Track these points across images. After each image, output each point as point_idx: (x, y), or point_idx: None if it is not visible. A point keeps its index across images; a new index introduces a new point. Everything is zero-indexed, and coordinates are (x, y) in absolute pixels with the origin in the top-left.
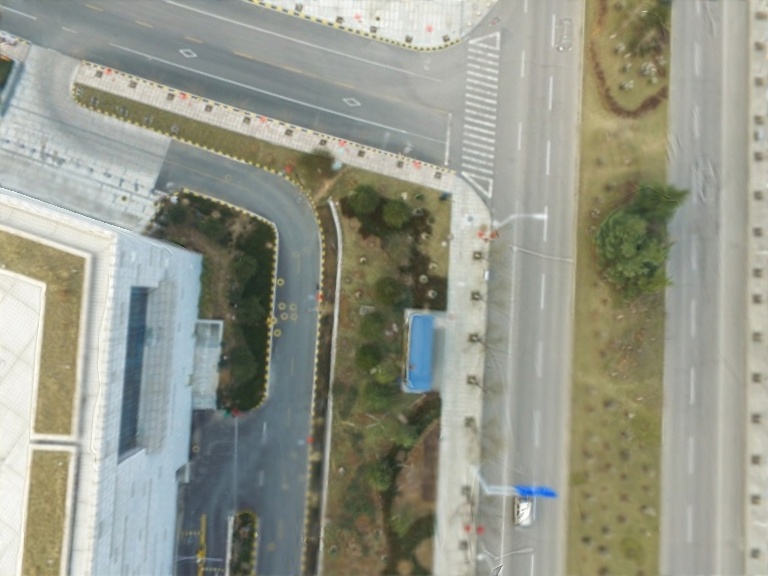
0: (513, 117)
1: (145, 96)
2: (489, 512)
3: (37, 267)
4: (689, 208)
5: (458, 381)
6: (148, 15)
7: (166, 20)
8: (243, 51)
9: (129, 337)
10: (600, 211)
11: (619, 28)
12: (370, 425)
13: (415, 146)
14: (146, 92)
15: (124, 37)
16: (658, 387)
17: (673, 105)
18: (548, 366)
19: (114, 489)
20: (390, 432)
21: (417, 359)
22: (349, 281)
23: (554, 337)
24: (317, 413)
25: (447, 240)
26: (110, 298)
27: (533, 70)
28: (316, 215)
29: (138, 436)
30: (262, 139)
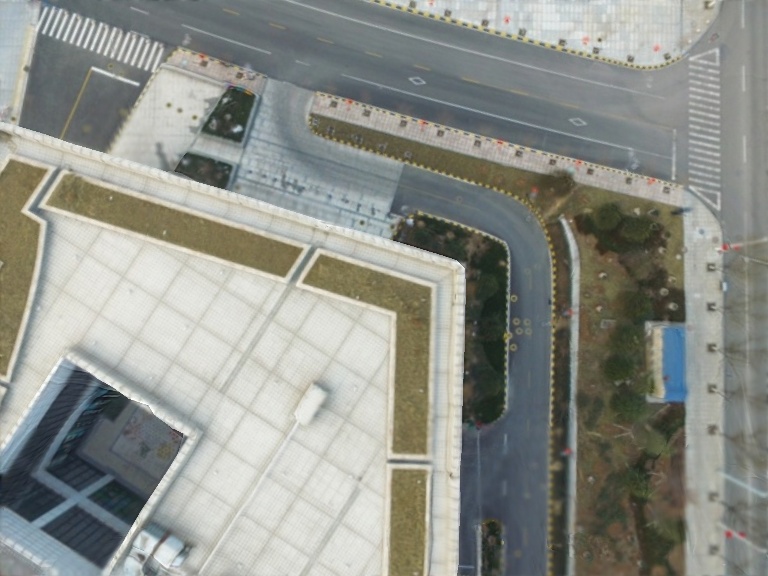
0: (737, 131)
1: (379, 124)
2: (766, 518)
3: (389, 297)
4: None
5: (700, 390)
6: (377, 46)
7: (395, 50)
8: (470, 77)
9: None
10: None
11: None
12: (618, 435)
13: (642, 162)
14: (380, 120)
15: (355, 68)
16: None
17: None
18: None
19: None
20: (640, 441)
21: (671, 370)
22: (589, 296)
23: None
24: (556, 424)
25: (681, 253)
26: (461, 325)
27: (754, 84)
28: (545, 232)
29: None
30: (493, 161)
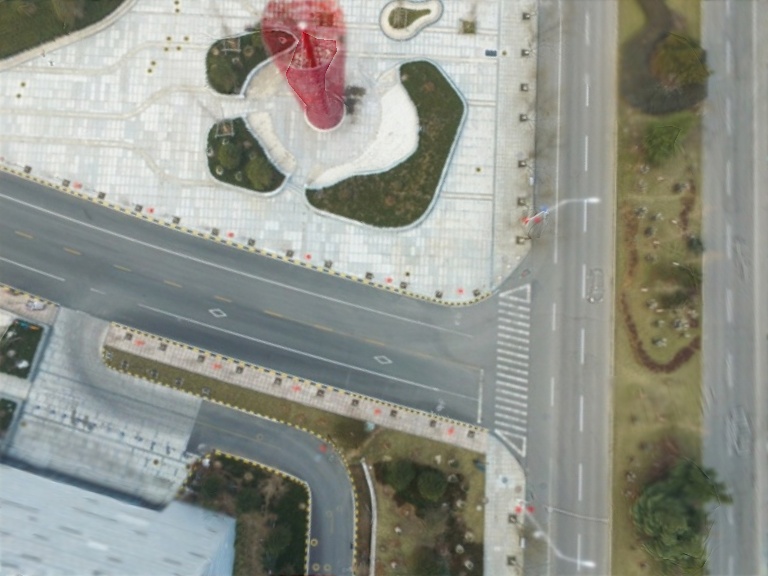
0: (545, 372)
1: (175, 359)
2: None
3: None
4: (724, 462)
5: None
6: (177, 275)
7: (195, 279)
8: (273, 309)
9: None
10: (636, 476)
11: (651, 283)
12: None
13: (447, 404)
14: (176, 355)
15: (153, 297)
16: None
17: (706, 356)
18: None
19: None
20: None
21: None
22: (384, 550)
23: None
24: None
25: (482, 504)
26: None
27: (564, 323)
28: (349, 473)
29: None
30: (293, 400)
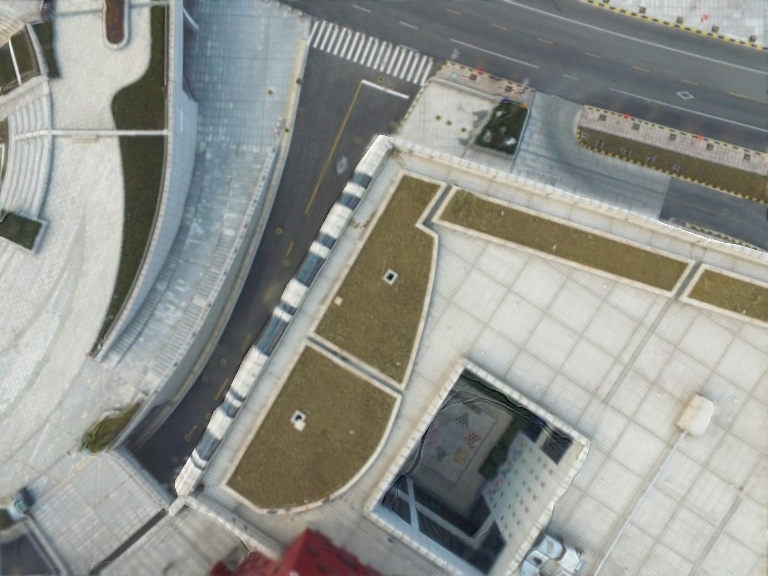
0: None
1: (648, 137)
2: None
3: None
4: None
5: None
6: (645, 60)
7: (662, 64)
8: (738, 91)
9: None
10: None
11: None
12: None
13: None
14: (649, 133)
15: (623, 82)
16: None
17: None
18: None
19: None
20: None
21: None
22: None
23: None
24: None
25: None
26: None
27: None
28: None
29: None
30: (763, 174)
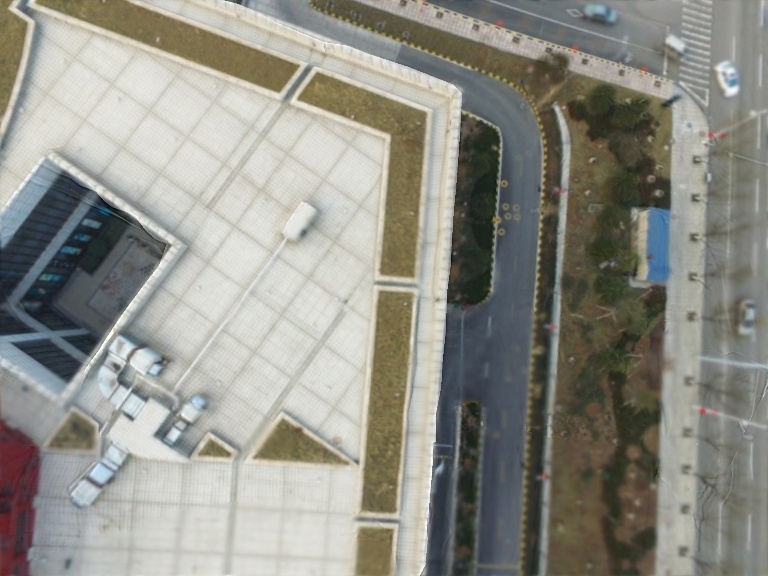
0: (727, 31)
1: (378, 1)
2: (740, 387)
3: (384, 118)
4: None
5: (681, 277)
6: None
7: None
8: None
9: None
10: None
11: None
12: (601, 316)
13: (635, 56)
14: None
15: None
16: None
17: None
18: (763, 266)
19: None
20: (621, 322)
21: (654, 250)
22: (578, 180)
23: None
24: (540, 309)
25: (669, 144)
26: (455, 148)
27: None
28: (538, 120)
29: None
30: (490, 45)
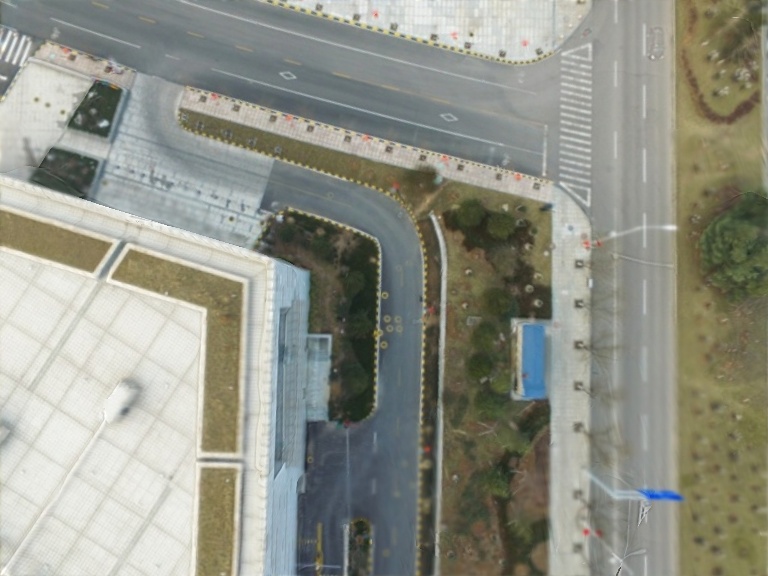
0: (608, 126)
1: (248, 119)
2: (614, 516)
3: (198, 293)
4: None
5: (566, 387)
6: (248, 40)
7: (265, 44)
8: (341, 71)
9: (279, 357)
10: (701, 217)
11: (711, 35)
12: (482, 433)
13: (513, 158)
14: (249, 115)
15: (225, 62)
16: (763, 388)
17: (766, 109)
18: (653, 370)
19: (272, 503)
20: (503, 439)
21: (530, 368)
22: (455, 293)
23: (658, 342)
24: (426, 422)
25: (549, 250)
26: (270, 321)
27: (626, 79)
28: (417, 229)
29: (283, 451)
30: (363, 157)
